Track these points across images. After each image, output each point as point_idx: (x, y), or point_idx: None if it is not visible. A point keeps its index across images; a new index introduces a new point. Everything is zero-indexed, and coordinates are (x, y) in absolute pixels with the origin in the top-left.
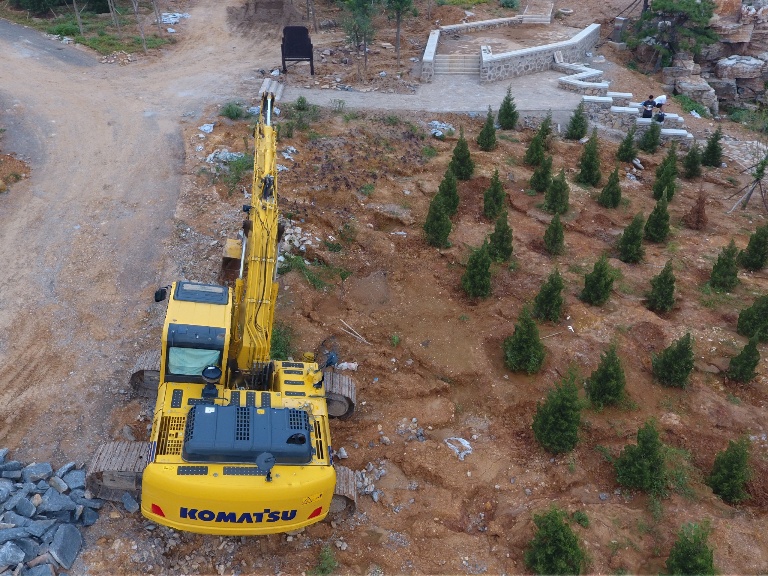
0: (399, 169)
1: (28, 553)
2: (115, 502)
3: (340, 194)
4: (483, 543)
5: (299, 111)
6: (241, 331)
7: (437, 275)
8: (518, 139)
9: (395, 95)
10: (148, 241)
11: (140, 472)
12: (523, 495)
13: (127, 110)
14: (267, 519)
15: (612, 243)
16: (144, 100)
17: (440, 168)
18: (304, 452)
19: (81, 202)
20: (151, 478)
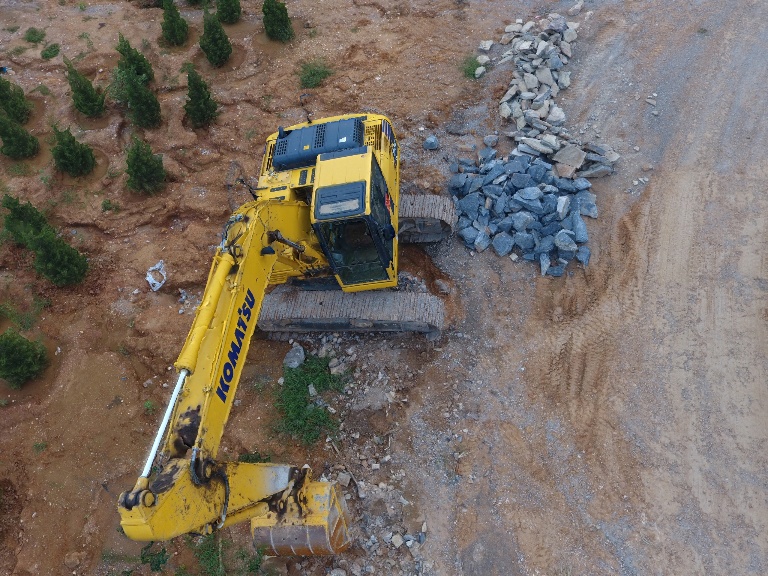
0: None
1: None
2: None
3: None
4: None
5: None
6: None
7: (8, 573)
8: None
9: None
10: None
11: None
12: None
13: None
14: None
15: None
16: None
17: None
18: None
19: None
20: None
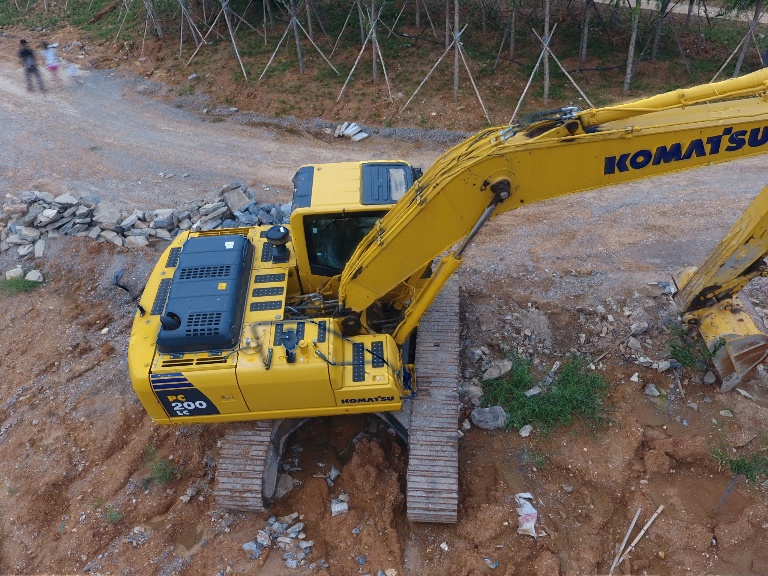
0: None
1: None
2: None
3: None
4: None
5: None
6: None
7: None
8: None
9: None
10: None
11: None
12: None
13: None
14: None
15: None
16: None
17: None
18: None
19: None
20: None
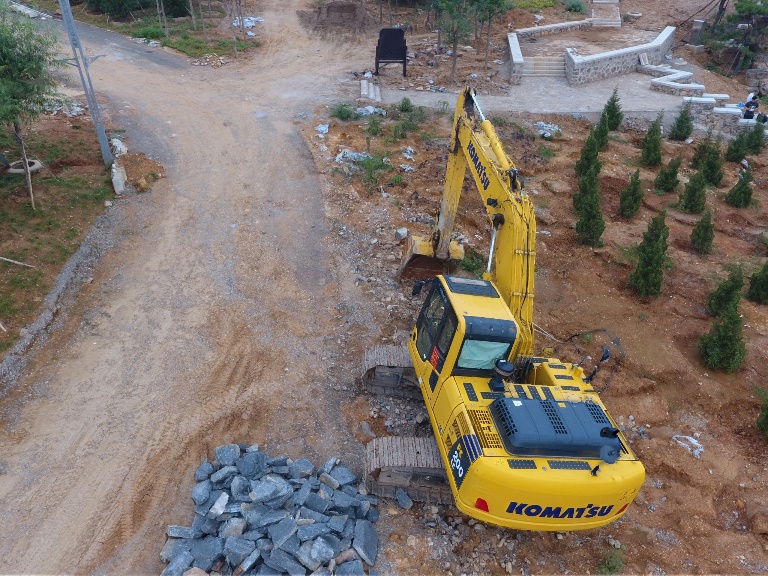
0: (521, 169)
1: (334, 549)
2: (386, 498)
3: (472, 194)
4: (753, 542)
5: (403, 112)
6: None
7: (599, 274)
8: (624, 140)
9: (490, 97)
10: (309, 239)
11: (424, 467)
12: (767, 494)
13: (238, 111)
14: (586, 514)
15: (755, 242)
16: (251, 101)
17: (561, 168)
18: (617, 446)
19: (227, 201)
20: (485, 471)
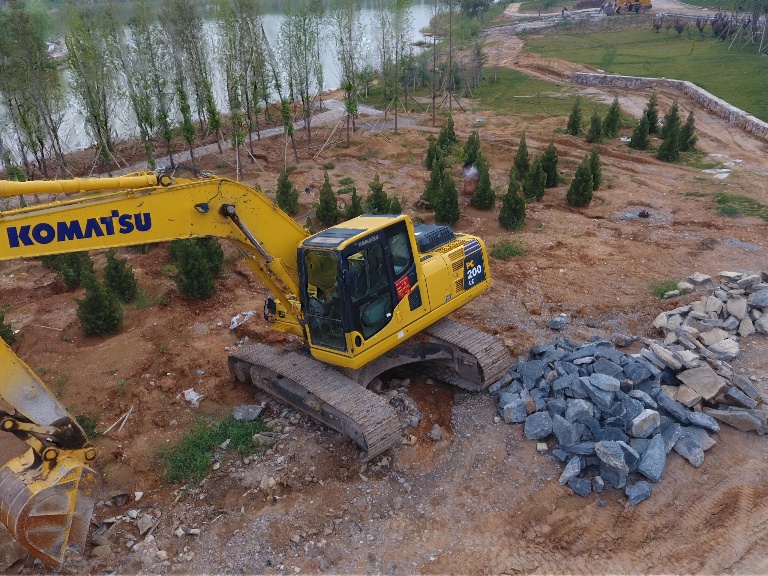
0: None
1: None
2: None
3: None
4: None
5: None
6: (328, 258)
7: None
8: None
9: None
10: None
11: None
12: None
13: None
14: None
15: None
16: None
17: None
18: None
19: None
20: None
